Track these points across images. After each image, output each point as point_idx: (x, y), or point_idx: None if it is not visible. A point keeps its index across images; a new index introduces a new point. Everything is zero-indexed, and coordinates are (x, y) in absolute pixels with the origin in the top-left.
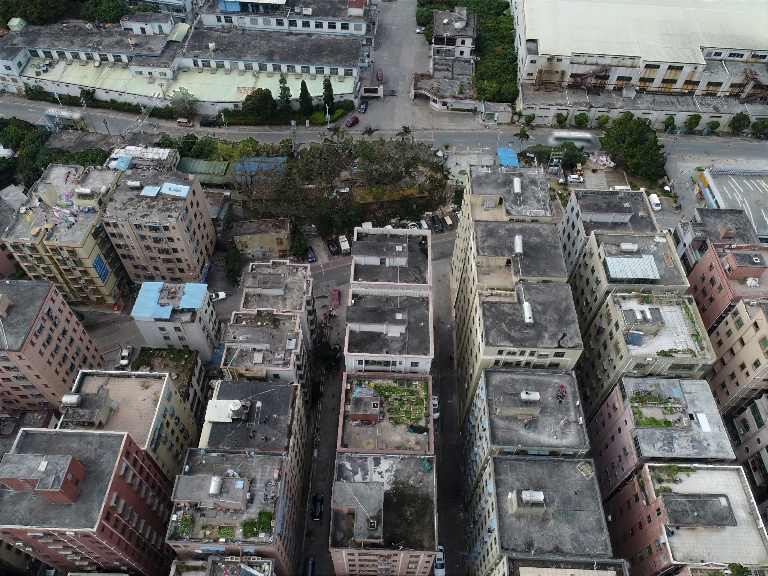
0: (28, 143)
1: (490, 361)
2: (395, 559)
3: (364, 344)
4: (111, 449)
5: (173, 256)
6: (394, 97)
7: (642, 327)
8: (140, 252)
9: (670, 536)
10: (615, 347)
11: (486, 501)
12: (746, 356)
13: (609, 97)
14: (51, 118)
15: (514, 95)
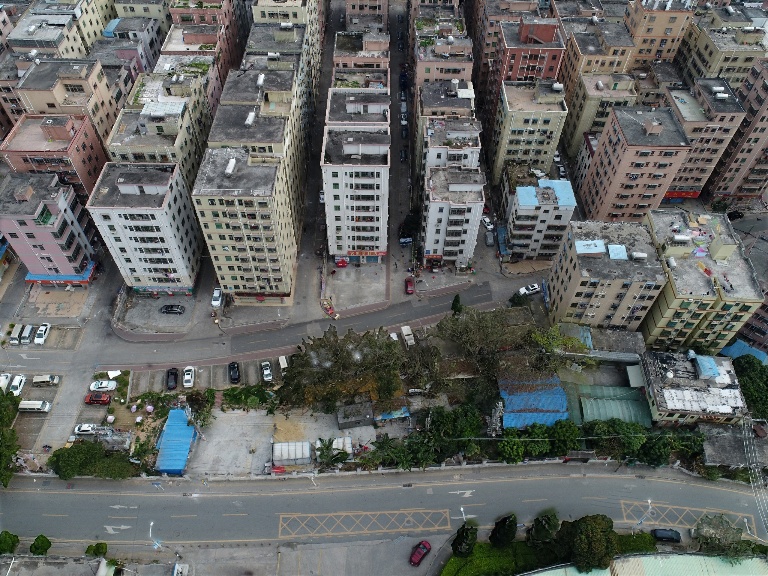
0: None
1: None
2: None
3: None
4: None
5: None
6: None
7: None
8: None
9: None
10: None
11: None
12: None
13: None
14: None
15: None
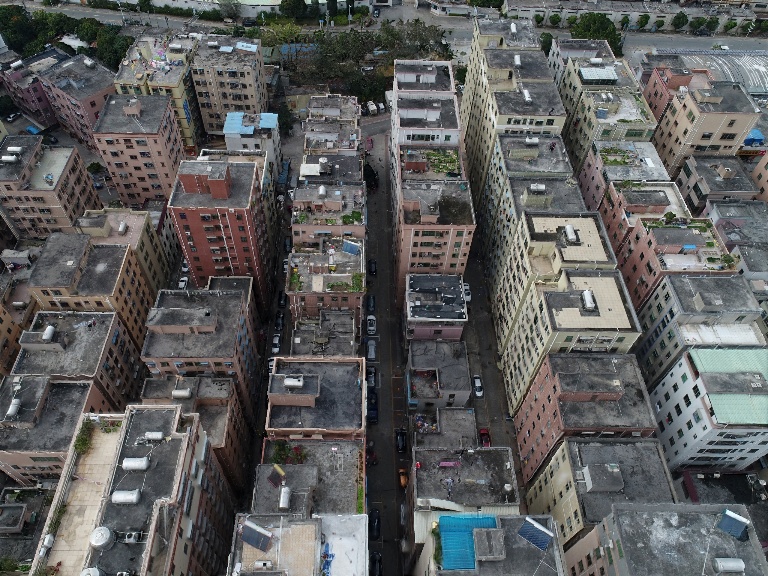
0: (104, 33)
1: (502, 131)
2: (446, 240)
3: (411, 125)
4: (246, 173)
5: (243, 103)
6: (401, 6)
7: (606, 106)
8: (217, 99)
9: (628, 217)
10: (588, 125)
11: (504, 212)
12: (679, 131)
13: (577, 2)
14: (114, 21)
15: (500, 2)
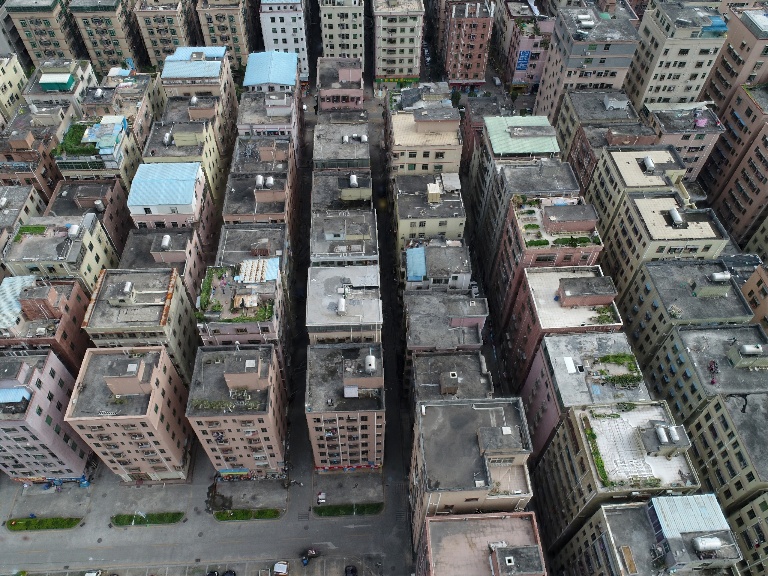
0: None
1: None
2: None
3: None
4: None
5: None
6: None
7: None
8: None
9: None
10: None
11: None
12: None
13: None
14: None
15: None
